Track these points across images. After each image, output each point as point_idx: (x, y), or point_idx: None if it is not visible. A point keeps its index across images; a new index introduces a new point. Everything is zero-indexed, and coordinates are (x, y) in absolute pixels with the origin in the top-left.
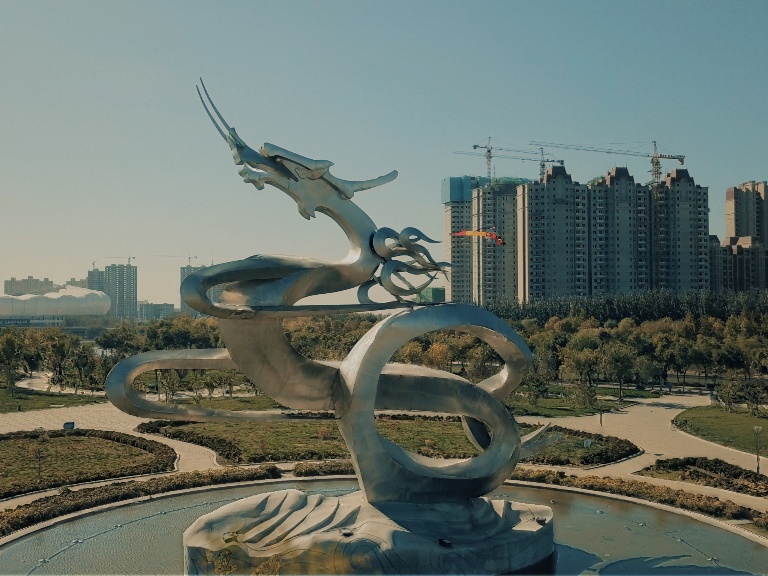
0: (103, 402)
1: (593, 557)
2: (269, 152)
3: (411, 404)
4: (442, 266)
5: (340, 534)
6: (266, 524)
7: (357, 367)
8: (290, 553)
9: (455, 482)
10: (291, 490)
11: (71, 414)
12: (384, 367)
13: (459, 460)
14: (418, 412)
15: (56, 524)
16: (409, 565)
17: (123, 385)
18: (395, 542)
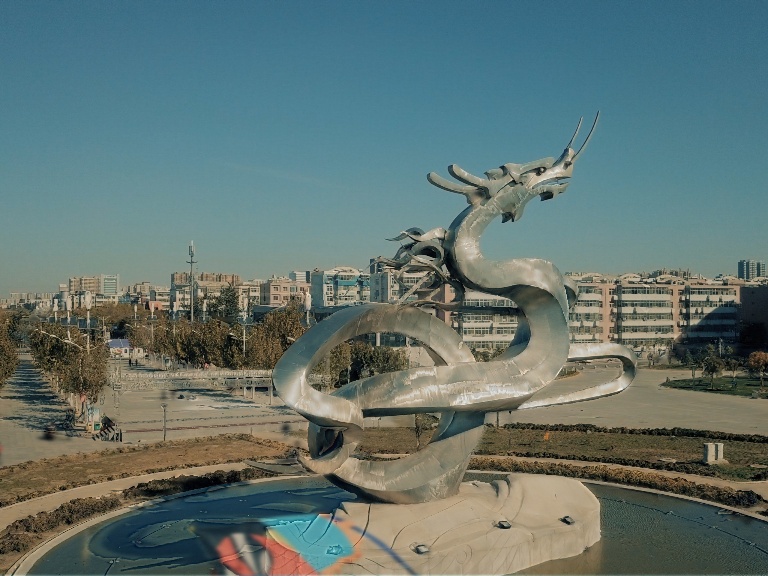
0: None
1: (231, 564)
2: None
3: None
4: (384, 263)
5: None
6: None
7: None
8: None
9: None
10: None
11: None
12: None
13: None
14: None
15: None
16: None
17: None
18: None
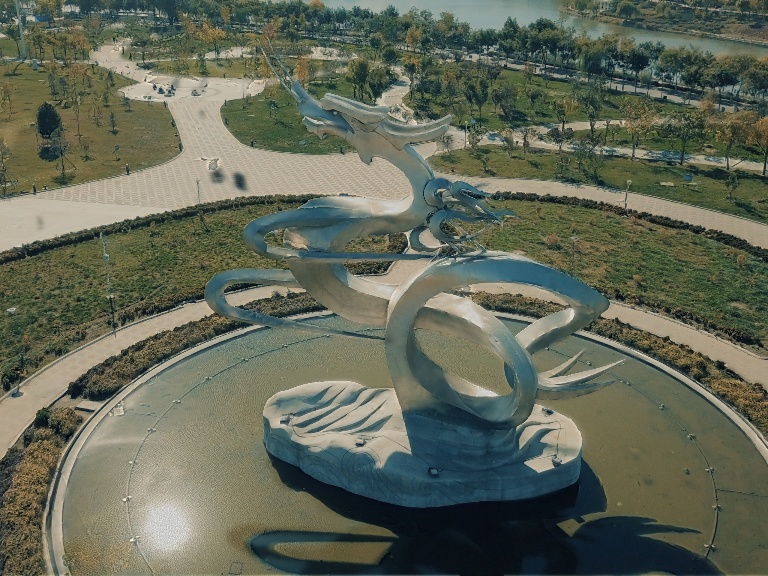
0: (418, 143)
1: (601, 503)
2: (326, 106)
3: (460, 334)
4: (501, 215)
5: (355, 442)
6: (317, 413)
7: (392, 309)
8: (314, 448)
9: (473, 416)
10: (350, 385)
11: (375, 164)
12: (439, 298)
13: (490, 393)
14: (697, 208)
15: (248, 333)
16: (395, 484)
17: (214, 296)
18: (386, 464)
